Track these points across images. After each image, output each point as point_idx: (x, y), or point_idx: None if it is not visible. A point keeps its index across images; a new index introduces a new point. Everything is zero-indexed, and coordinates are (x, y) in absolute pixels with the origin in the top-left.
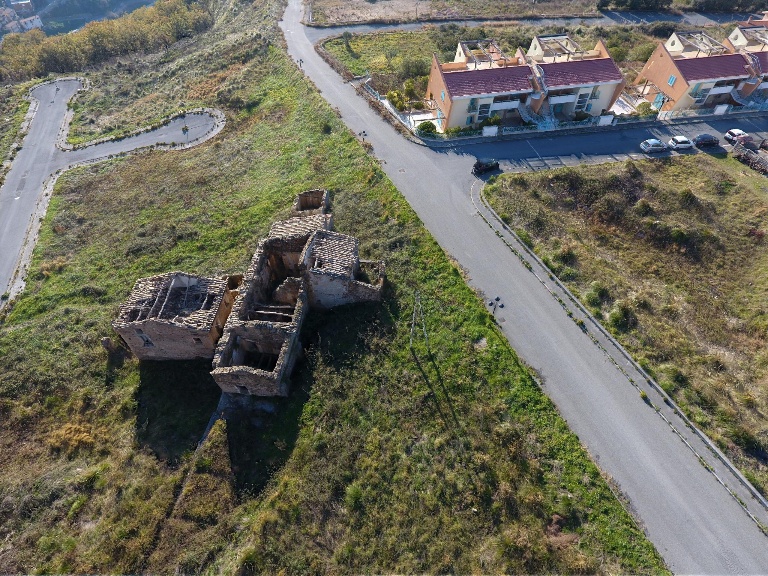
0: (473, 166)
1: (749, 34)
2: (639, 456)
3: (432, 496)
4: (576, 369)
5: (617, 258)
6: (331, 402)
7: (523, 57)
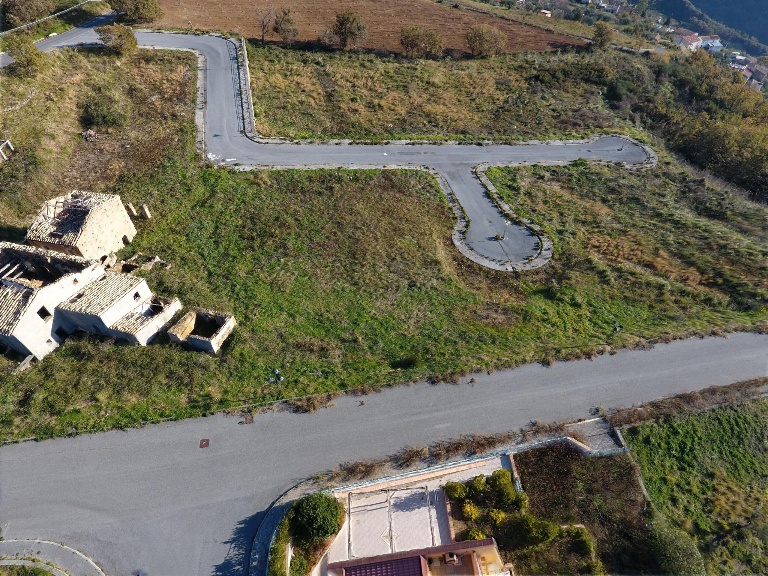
0: None
1: None
2: None
3: None
4: None
5: None
6: None
7: None
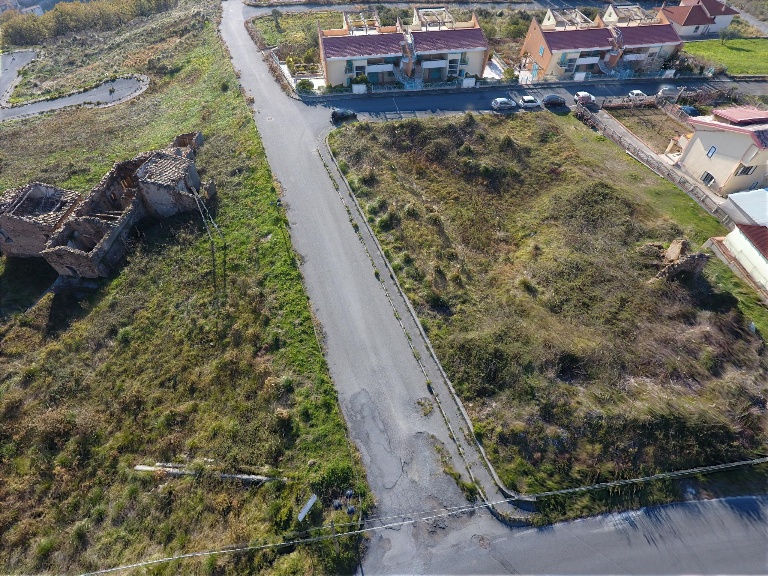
0: (331, 115)
1: (620, 11)
2: (349, 310)
3: (181, 334)
4: (334, 256)
5: (428, 188)
6: (132, 276)
7: (400, 26)
